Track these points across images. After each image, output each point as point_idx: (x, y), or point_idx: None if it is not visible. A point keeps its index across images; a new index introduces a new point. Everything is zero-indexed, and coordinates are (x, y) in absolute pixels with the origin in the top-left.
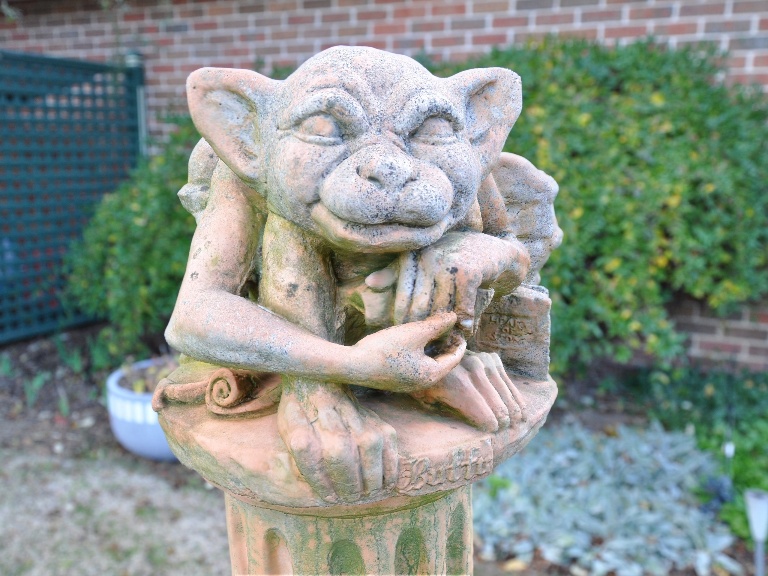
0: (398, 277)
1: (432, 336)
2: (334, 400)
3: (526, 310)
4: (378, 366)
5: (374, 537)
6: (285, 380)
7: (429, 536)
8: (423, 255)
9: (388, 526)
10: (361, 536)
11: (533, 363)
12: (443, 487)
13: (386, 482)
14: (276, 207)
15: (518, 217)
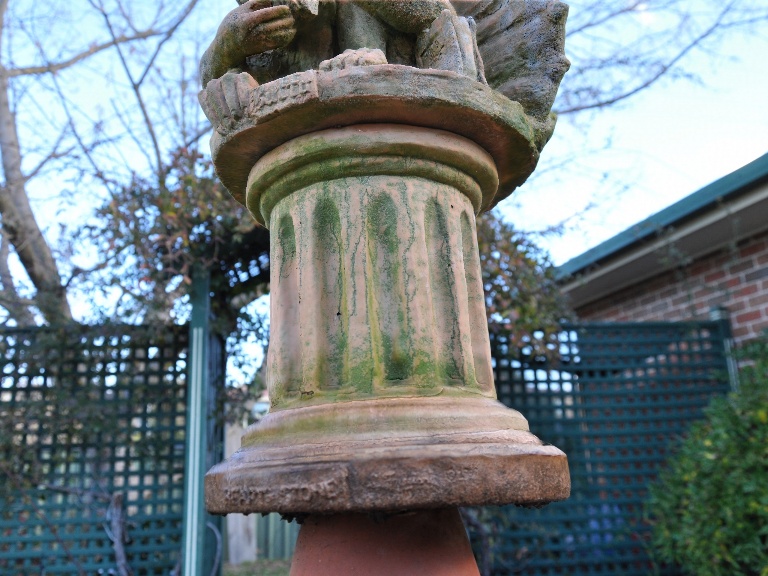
0: None
1: (254, 2)
2: None
3: None
4: None
5: (299, 206)
6: None
7: (341, 207)
8: None
9: (307, 196)
10: (292, 208)
11: (450, 69)
12: (278, 107)
13: (241, 107)
14: None
15: (508, 5)
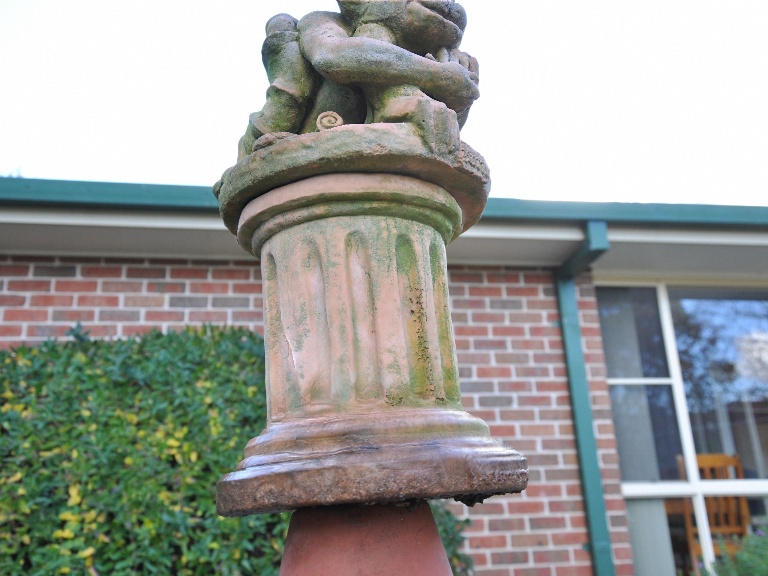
0: (439, 60)
1: None
2: None
3: None
4: (457, 69)
5: (420, 236)
6: (391, 94)
7: (441, 256)
8: (452, 49)
9: (425, 233)
10: (413, 233)
11: None
12: (474, 171)
13: (456, 147)
14: (376, 14)
15: None
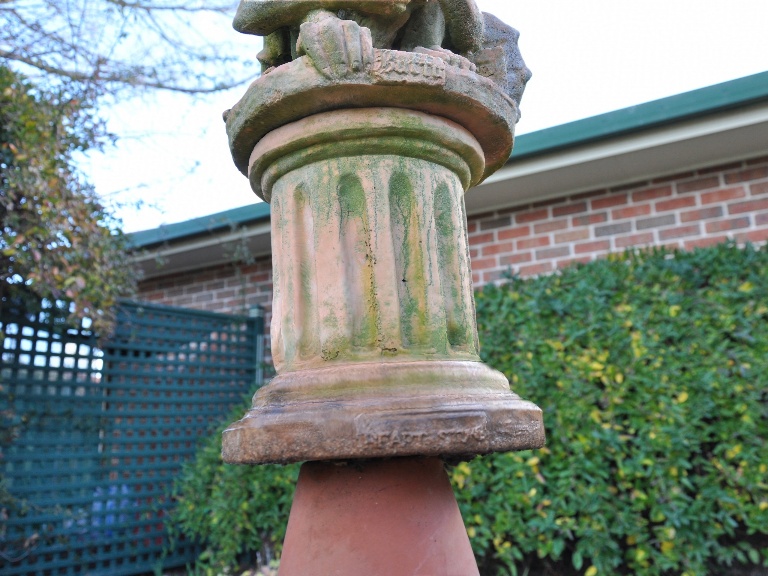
0: None
1: None
2: (330, 15)
3: (486, 57)
4: None
5: (371, 171)
6: None
7: (416, 184)
8: None
9: (382, 164)
10: (361, 170)
11: None
12: (407, 78)
13: (364, 61)
14: None
15: None
